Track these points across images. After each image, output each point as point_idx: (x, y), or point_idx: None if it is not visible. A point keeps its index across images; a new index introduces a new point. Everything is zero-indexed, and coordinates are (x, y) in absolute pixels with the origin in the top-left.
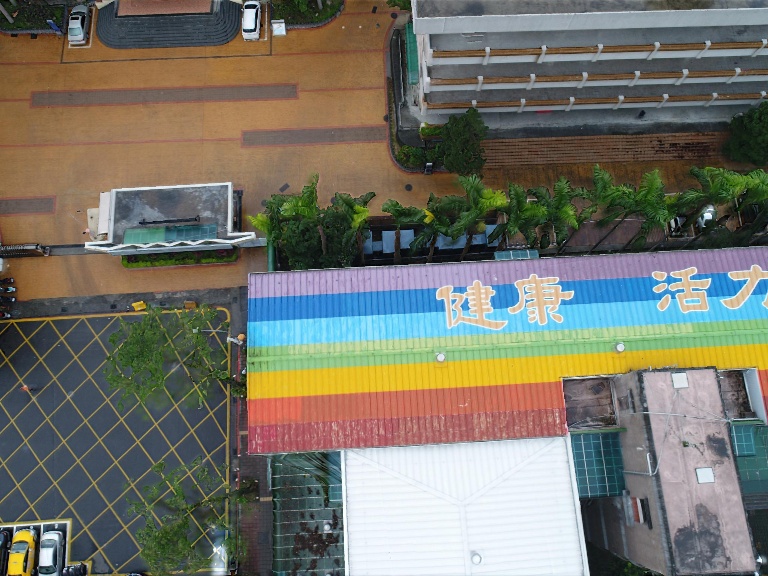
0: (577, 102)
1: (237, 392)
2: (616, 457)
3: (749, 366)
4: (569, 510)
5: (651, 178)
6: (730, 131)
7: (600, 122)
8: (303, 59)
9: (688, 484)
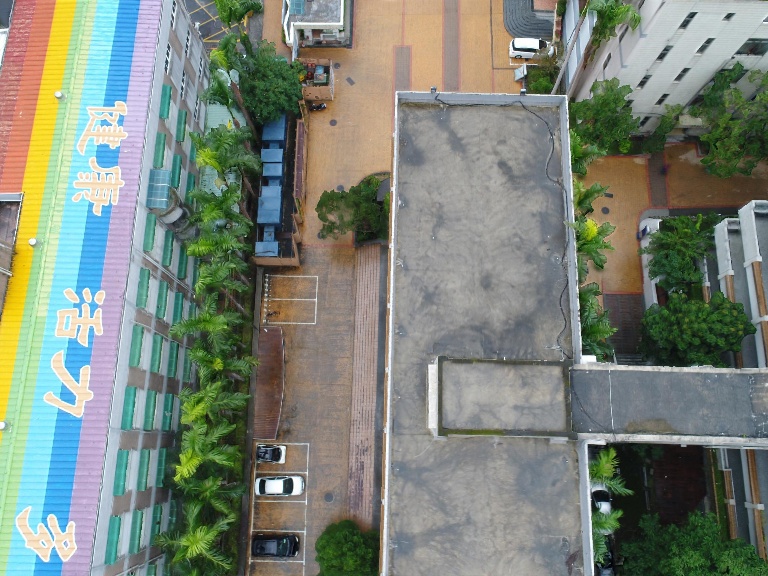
0: None
1: None
2: None
3: None
4: None
5: (217, 322)
6: None
7: None
8: None
9: None
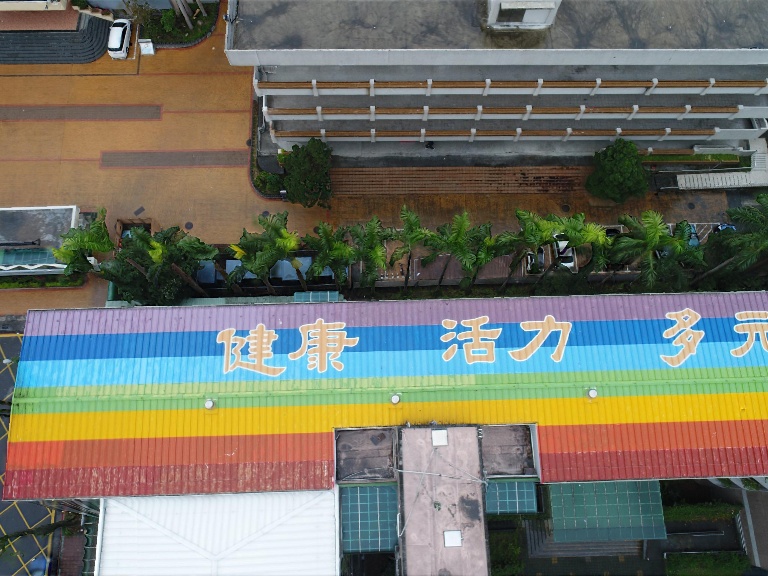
0: (428, 134)
1: None
2: (392, 511)
3: (529, 421)
4: (330, 567)
5: (460, 221)
6: (594, 166)
7: (463, 153)
8: (170, 80)
9: (434, 547)
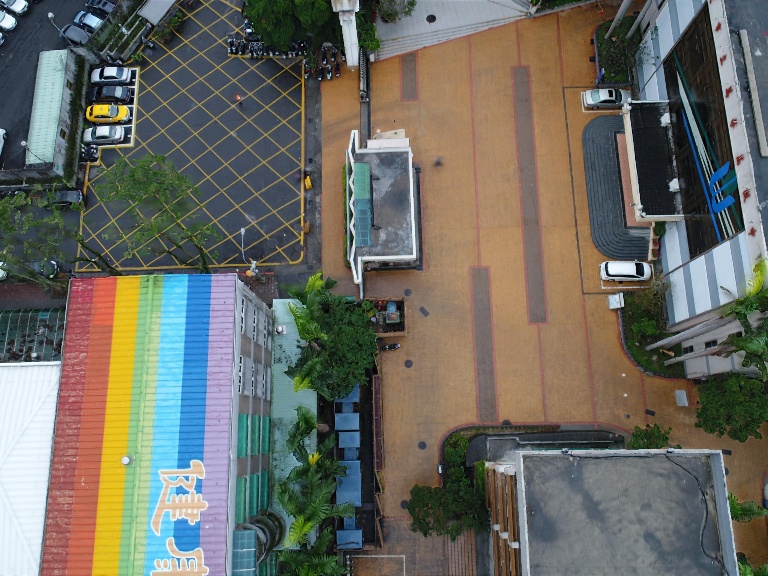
0: None
1: (202, 272)
2: None
3: None
4: None
5: None
6: None
7: None
8: (579, 329)
9: None
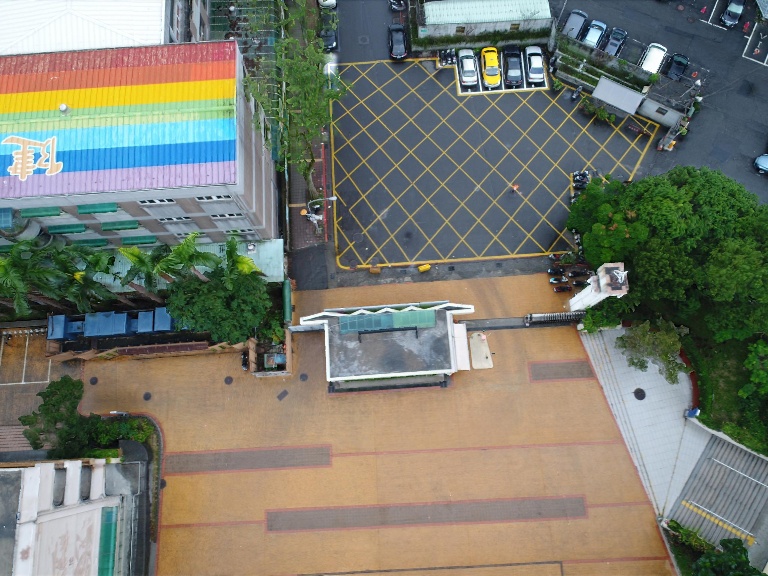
0: None
1: None
2: None
3: None
4: None
5: None
6: None
7: None
8: (258, 569)
9: None
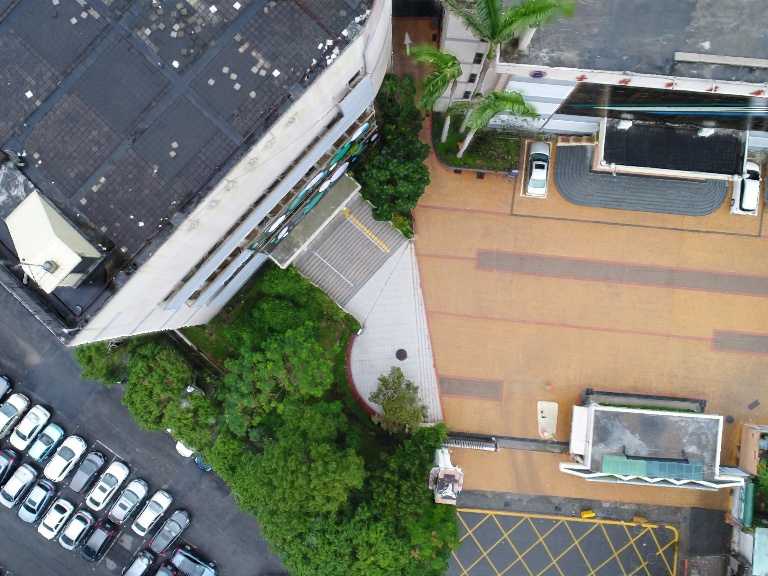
0: None
1: None
2: None
3: None
4: None
5: None
6: None
7: None
8: None
9: None
